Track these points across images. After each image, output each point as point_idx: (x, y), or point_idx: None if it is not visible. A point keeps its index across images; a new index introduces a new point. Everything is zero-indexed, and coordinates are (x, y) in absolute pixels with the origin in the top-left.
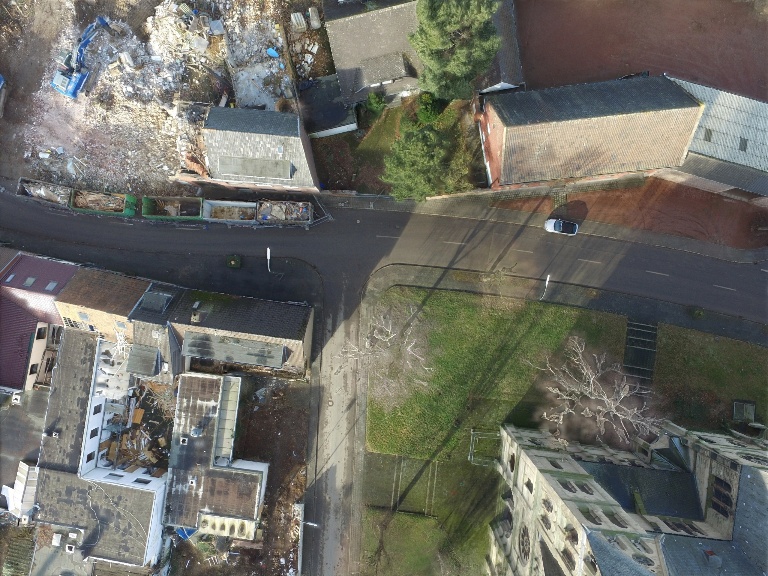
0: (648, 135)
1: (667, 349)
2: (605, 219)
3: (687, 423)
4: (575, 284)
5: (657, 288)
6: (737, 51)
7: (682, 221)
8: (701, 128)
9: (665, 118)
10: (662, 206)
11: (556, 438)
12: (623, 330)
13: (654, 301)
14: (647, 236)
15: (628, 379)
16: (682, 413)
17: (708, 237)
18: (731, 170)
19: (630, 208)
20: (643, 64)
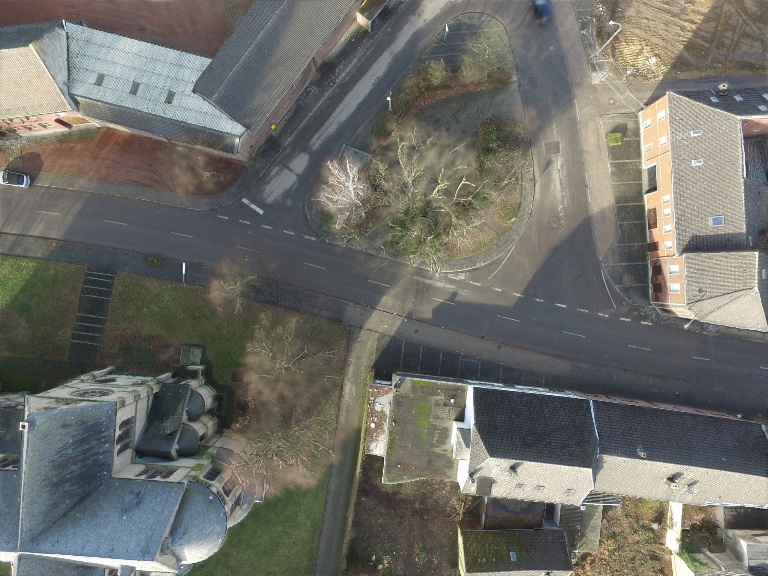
0: (4, 78)
1: (122, 297)
2: (61, 170)
3: (136, 369)
4: (35, 236)
5: (116, 237)
6: (182, 1)
7: (137, 170)
8: (94, 73)
9: (4, 59)
10: (116, 156)
11: (8, 389)
12: (79, 280)
13: (113, 250)
14: (104, 186)
15: (81, 328)
16: (131, 359)
17: (163, 185)
18: (124, 113)
19: (84, 158)
20: (90, 15)
